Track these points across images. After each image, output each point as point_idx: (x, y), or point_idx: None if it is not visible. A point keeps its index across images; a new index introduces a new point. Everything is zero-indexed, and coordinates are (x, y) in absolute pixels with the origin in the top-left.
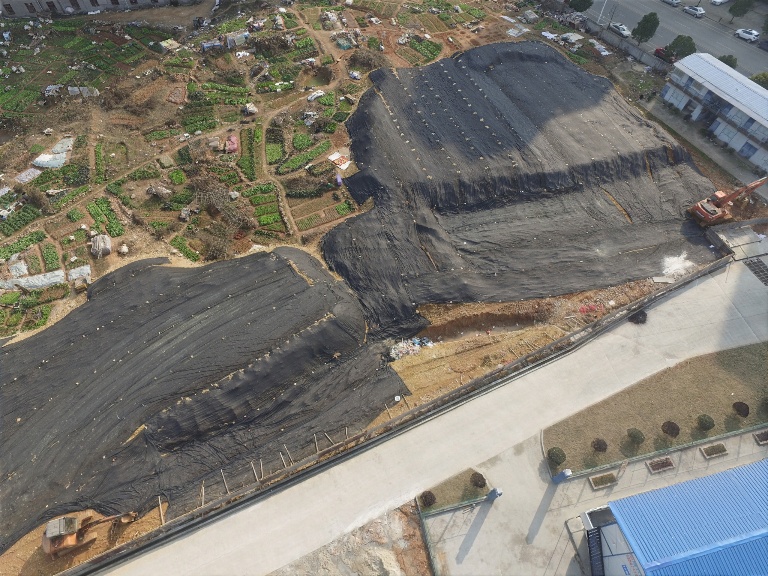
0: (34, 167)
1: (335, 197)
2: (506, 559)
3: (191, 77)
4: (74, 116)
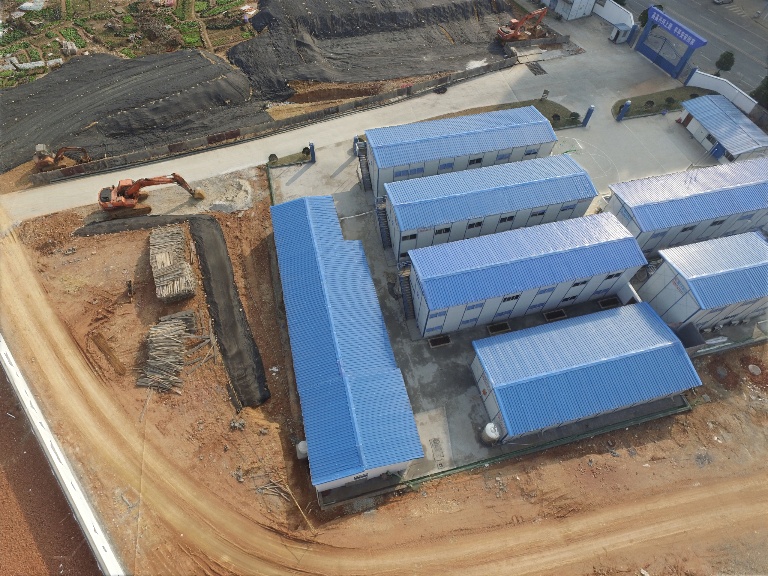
0: (20, 11)
1: (242, 28)
2: (316, 184)
3: None
4: None
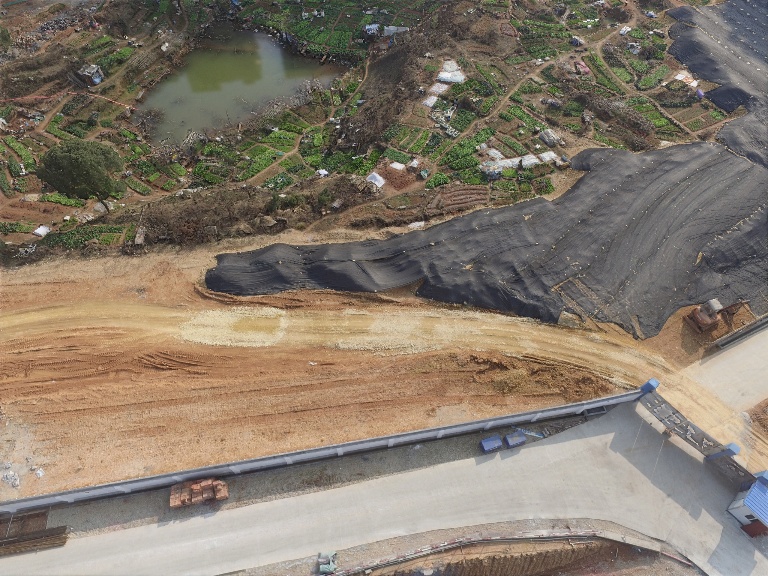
0: (439, 82)
1: (705, 107)
2: None
3: (511, 15)
4: (441, 44)
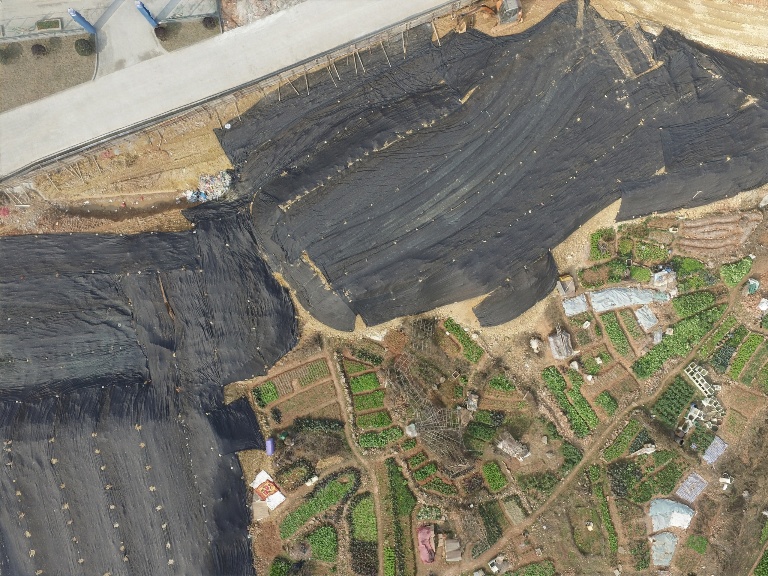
0: (689, 504)
1: (277, 414)
2: None
3: None
4: None
